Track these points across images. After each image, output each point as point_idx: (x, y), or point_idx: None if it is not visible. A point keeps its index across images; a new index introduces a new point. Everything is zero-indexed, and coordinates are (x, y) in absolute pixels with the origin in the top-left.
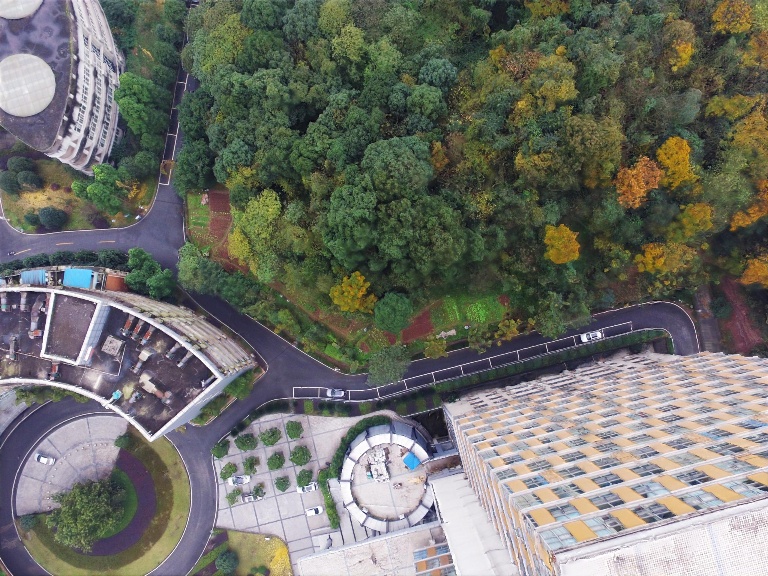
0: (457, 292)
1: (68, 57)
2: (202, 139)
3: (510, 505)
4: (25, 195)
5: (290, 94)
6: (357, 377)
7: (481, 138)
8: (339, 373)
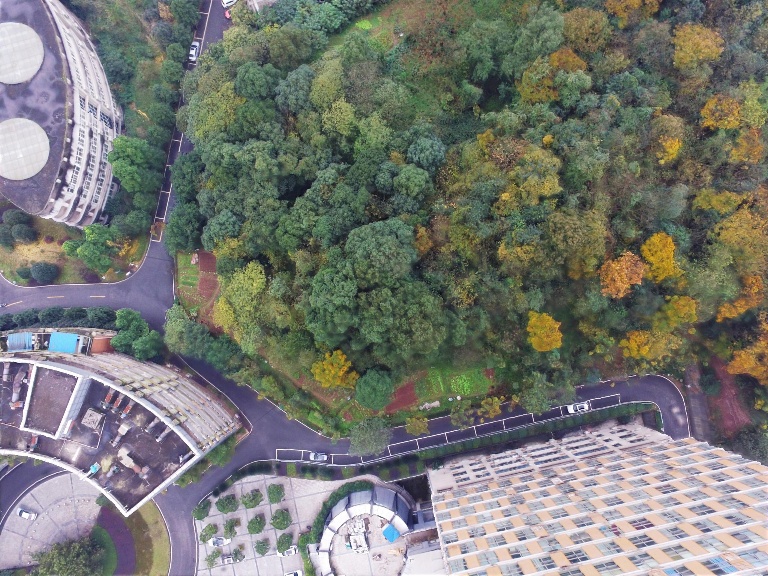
0: (442, 364)
1: (63, 122)
2: (193, 202)
3: None
4: (19, 247)
5: (279, 166)
6: (341, 441)
7: (466, 223)
8: (323, 436)
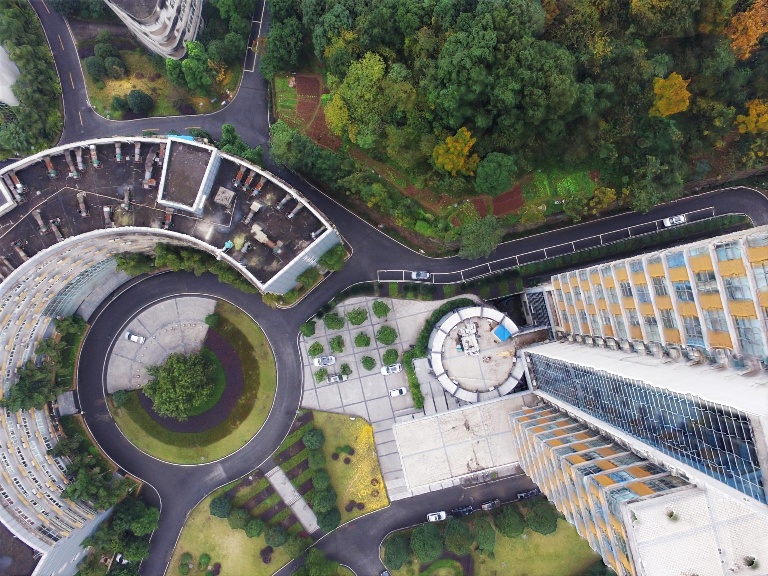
0: (549, 166)
1: None
2: (294, 16)
3: (686, 257)
4: (110, 83)
5: None
6: (441, 261)
7: None
8: (423, 256)
